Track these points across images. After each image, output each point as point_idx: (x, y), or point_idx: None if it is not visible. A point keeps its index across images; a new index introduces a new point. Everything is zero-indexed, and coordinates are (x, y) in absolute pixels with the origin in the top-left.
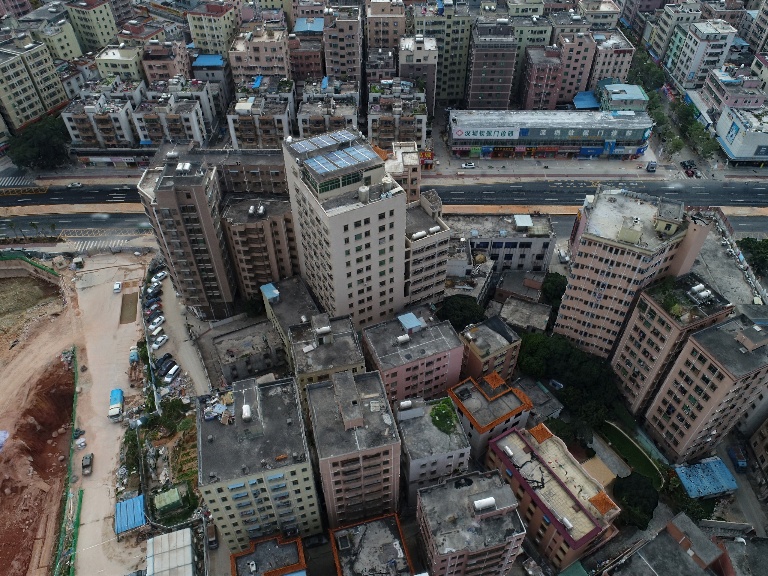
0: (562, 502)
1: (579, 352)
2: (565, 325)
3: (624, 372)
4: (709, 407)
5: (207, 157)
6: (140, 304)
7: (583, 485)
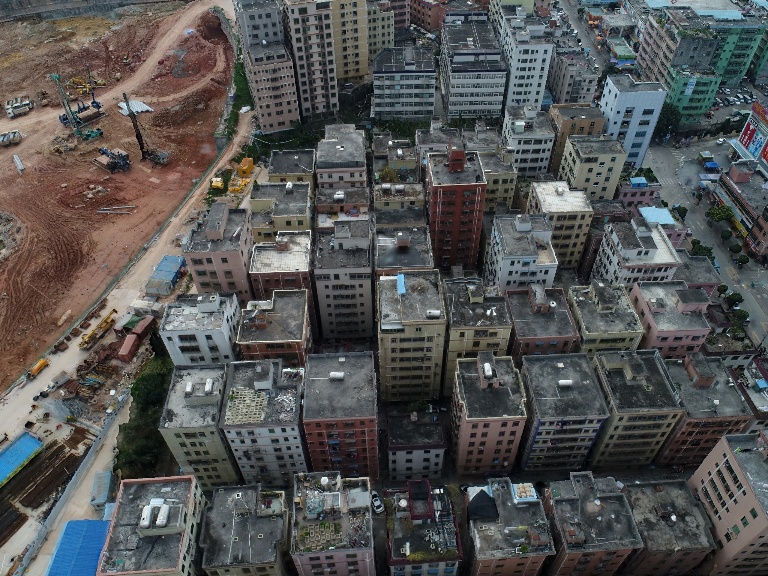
0: (429, 0)
1: None
2: None
3: None
4: None
5: None
6: None
7: None
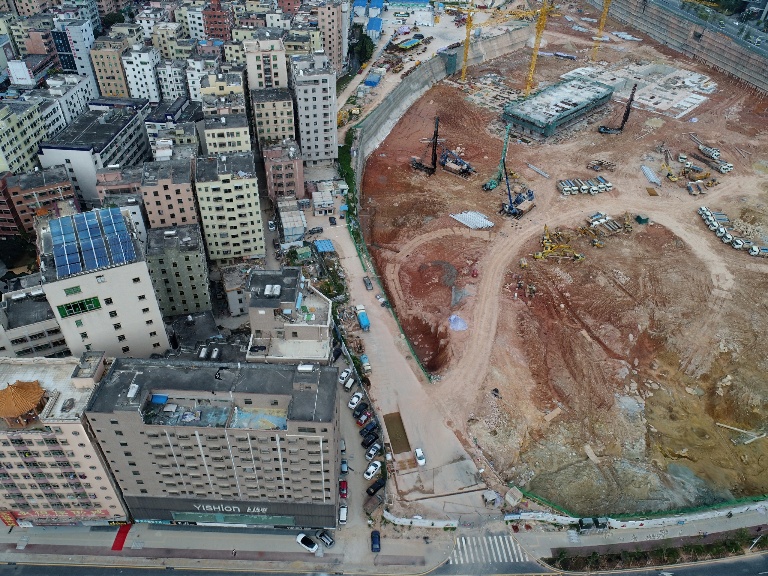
0: (66, 212)
1: None
2: None
3: None
4: None
5: (263, 390)
6: None
7: None
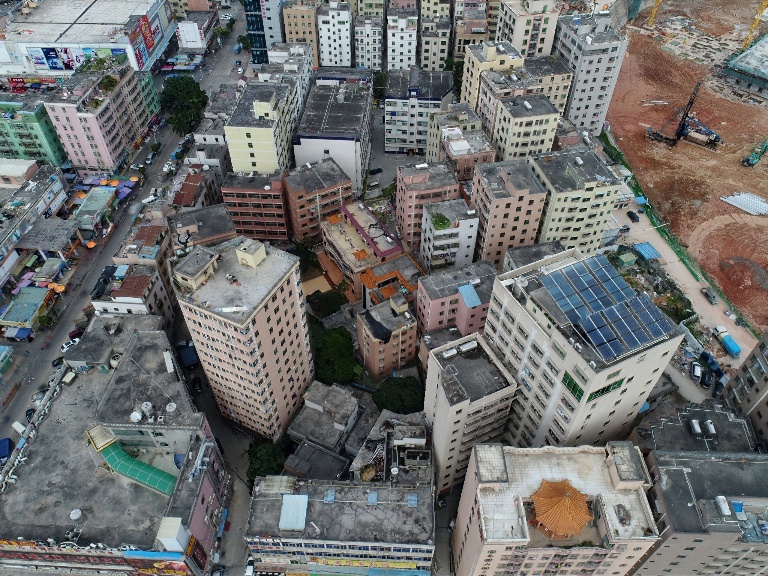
0: (361, 218)
1: None
2: None
3: None
4: None
5: None
6: None
7: (339, 239)
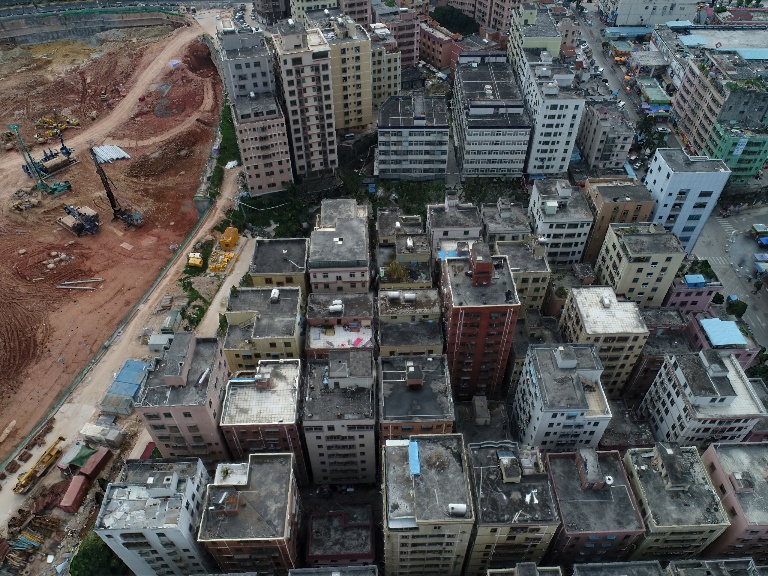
0: (440, 35)
1: (458, 9)
2: (452, 0)
3: (479, 18)
4: (506, 5)
5: None
6: (234, 19)
7: None
